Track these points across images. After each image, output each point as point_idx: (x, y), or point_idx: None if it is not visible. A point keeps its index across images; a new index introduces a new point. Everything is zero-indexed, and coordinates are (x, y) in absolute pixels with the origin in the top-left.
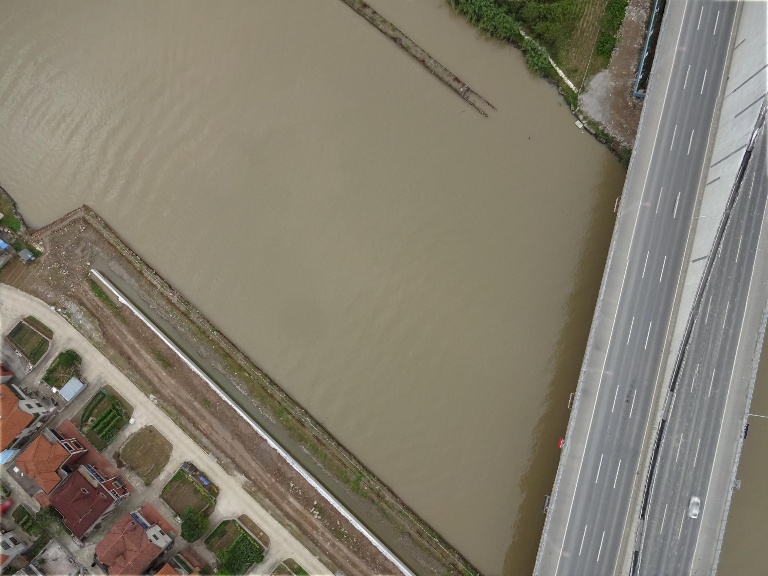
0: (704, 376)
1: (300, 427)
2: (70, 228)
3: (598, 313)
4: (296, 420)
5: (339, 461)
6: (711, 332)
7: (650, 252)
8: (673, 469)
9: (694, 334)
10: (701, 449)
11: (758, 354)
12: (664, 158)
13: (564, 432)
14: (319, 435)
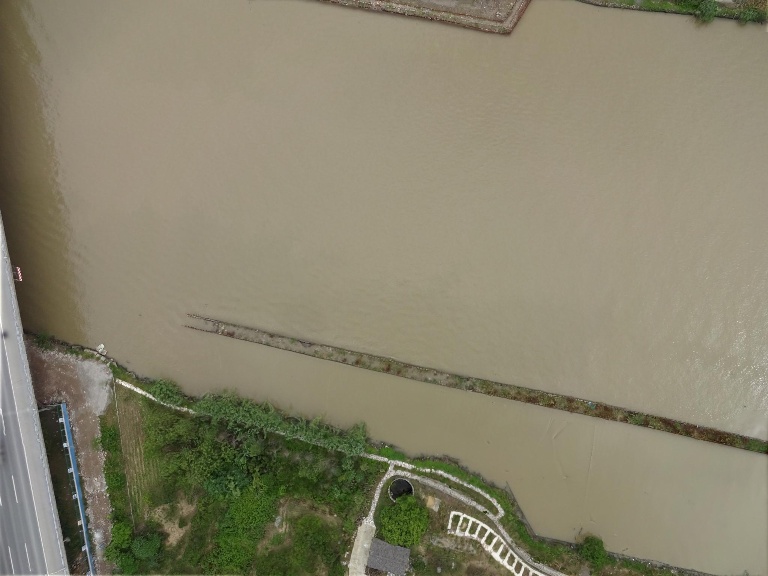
0: None
1: None
2: (509, 8)
3: None
4: None
5: None
6: None
7: None
8: None
9: None
10: None
11: None
12: None
13: None
14: None
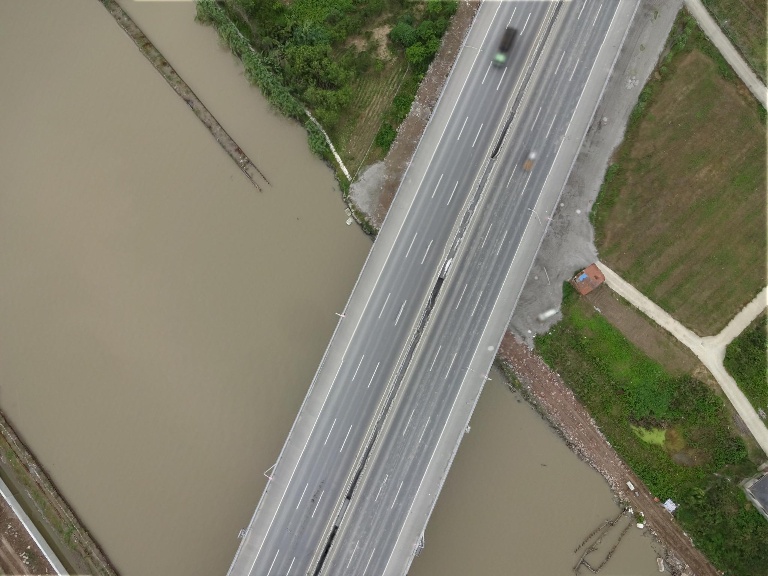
0: (391, 487)
1: (25, 472)
2: None
3: (302, 409)
4: (22, 464)
5: (56, 511)
6: (407, 444)
7: (365, 356)
8: (343, 574)
9: (390, 444)
10: (373, 559)
11: (445, 474)
12: (398, 264)
13: (248, 521)
14: (41, 482)
